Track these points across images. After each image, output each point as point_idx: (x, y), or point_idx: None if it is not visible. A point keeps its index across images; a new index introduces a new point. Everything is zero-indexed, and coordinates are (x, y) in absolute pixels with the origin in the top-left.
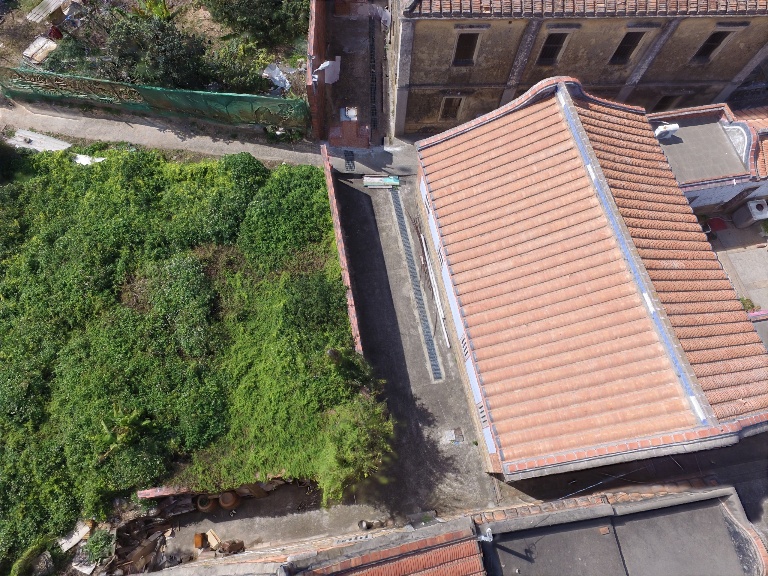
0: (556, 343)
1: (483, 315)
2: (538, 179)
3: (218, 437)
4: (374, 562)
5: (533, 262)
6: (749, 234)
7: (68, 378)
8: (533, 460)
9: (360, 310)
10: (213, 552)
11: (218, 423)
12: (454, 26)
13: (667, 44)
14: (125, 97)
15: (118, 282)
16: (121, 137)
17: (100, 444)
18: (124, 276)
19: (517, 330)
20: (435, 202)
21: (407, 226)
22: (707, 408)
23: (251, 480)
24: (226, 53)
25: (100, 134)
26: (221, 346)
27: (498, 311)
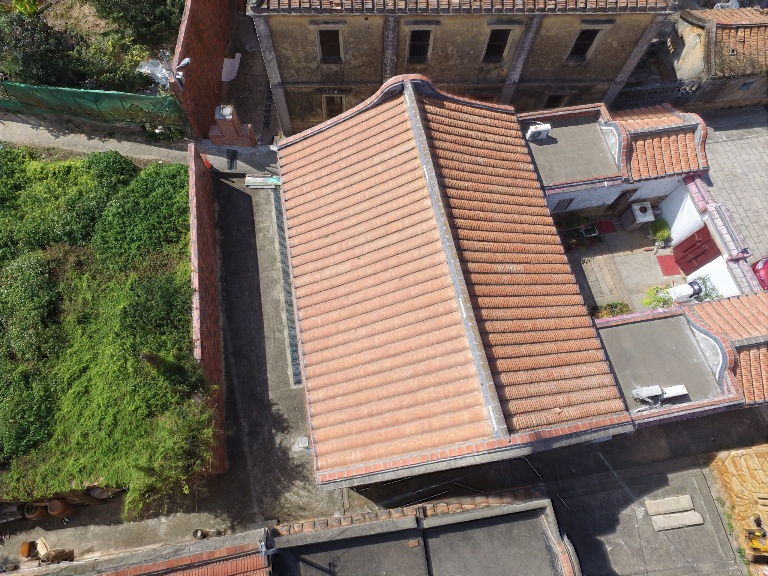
0: (379, 349)
1: (317, 319)
2: (381, 179)
3: (40, 443)
4: None
5: (368, 265)
6: (638, 237)
7: None
8: (343, 470)
9: (226, 313)
10: (37, 561)
11: (40, 429)
12: (309, 22)
13: (537, 42)
14: None
15: None
16: None
17: None
18: None
19: (345, 335)
20: (287, 203)
21: None
22: (499, 418)
23: (65, 488)
24: (96, 49)
25: None
26: (55, 349)
27: (331, 315)
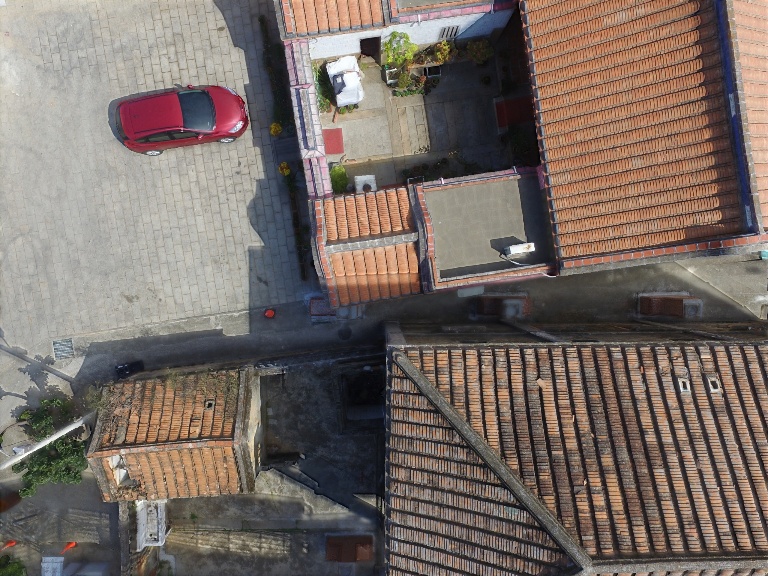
0: None
1: None
2: (764, 127)
3: None
4: None
5: (767, 33)
6: None
7: None
8: None
9: None
10: None
11: None
12: None
13: None
14: None
15: None
16: None
17: None
18: None
19: None
20: None
21: None
22: None
23: None
24: None
25: None
26: None
27: None
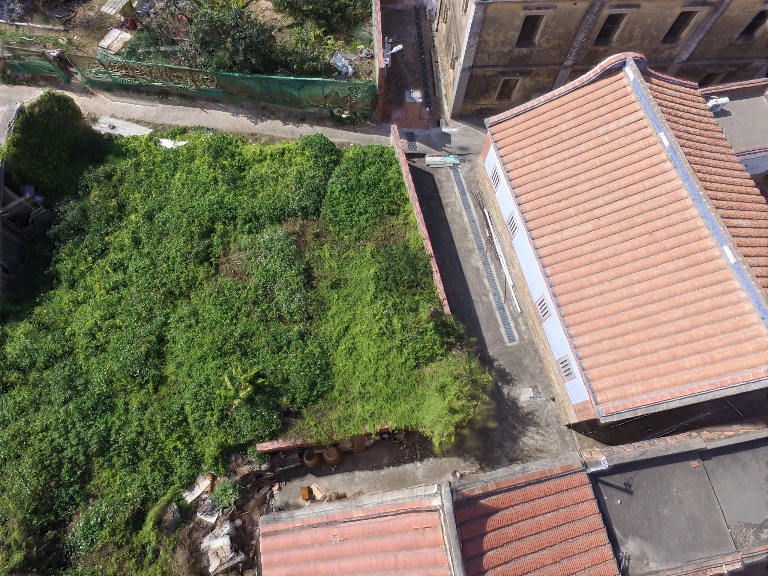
0: (640, 296)
1: (566, 275)
2: (611, 148)
3: (325, 394)
4: (506, 487)
5: (612, 224)
6: None
7: (182, 343)
8: (627, 402)
9: None
10: None
11: (324, 381)
12: (523, 8)
13: (717, 22)
14: (198, 84)
15: (215, 255)
16: (197, 122)
17: (221, 401)
18: (220, 250)
19: (601, 286)
20: (510, 174)
21: (470, 202)
22: None
23: (361, 431)
24: (297, 40)
25: (177, 120)
26: (319, 311)
27: (581, 270)
